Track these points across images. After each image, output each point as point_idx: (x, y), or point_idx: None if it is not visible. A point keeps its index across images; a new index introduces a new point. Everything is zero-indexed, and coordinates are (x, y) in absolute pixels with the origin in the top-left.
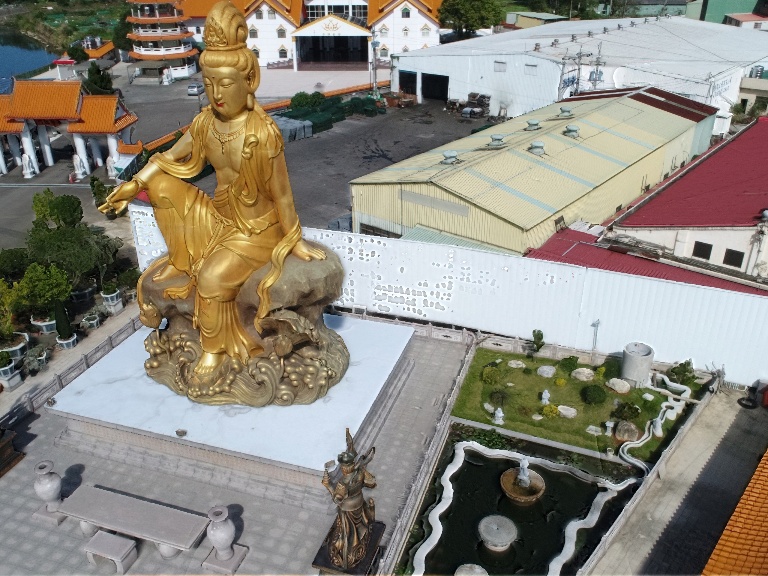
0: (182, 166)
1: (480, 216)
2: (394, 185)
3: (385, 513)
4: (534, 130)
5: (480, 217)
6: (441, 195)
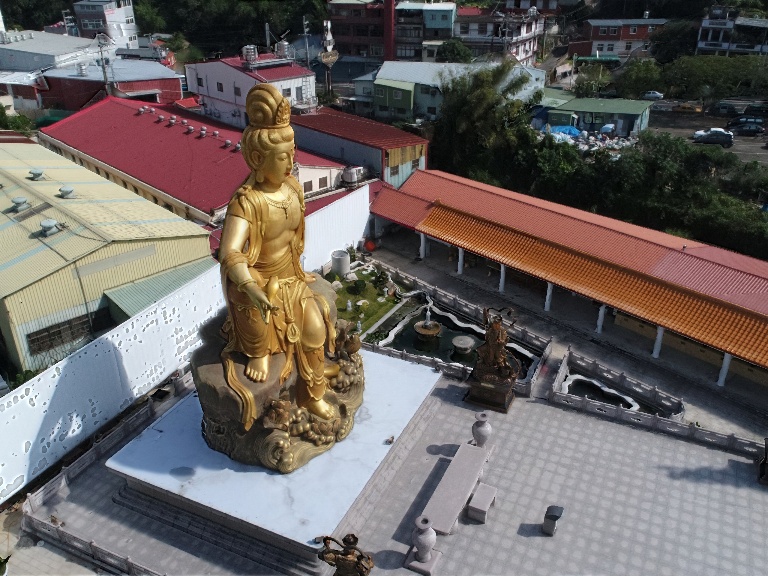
0: (250, 254)
1: (168, 246)
2: (66, 268)
3: (442, 383)
4: (2, 188)
5: (168, 247)
6: (124, 249)
